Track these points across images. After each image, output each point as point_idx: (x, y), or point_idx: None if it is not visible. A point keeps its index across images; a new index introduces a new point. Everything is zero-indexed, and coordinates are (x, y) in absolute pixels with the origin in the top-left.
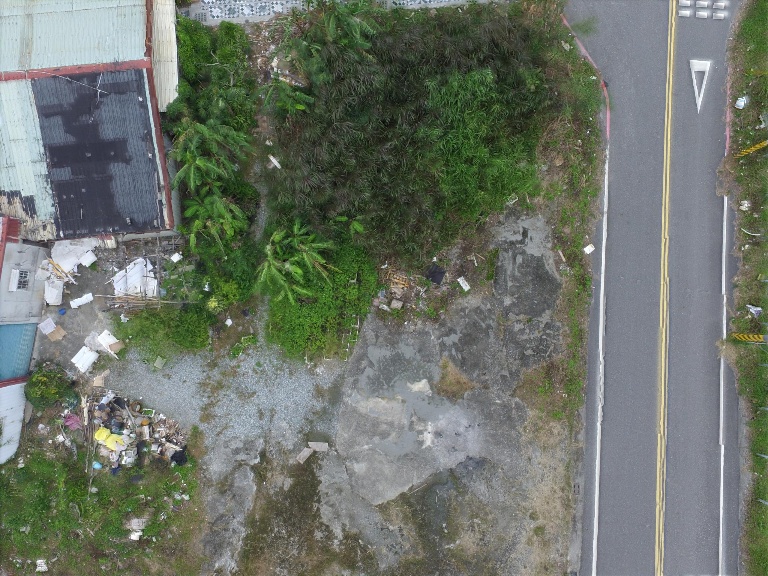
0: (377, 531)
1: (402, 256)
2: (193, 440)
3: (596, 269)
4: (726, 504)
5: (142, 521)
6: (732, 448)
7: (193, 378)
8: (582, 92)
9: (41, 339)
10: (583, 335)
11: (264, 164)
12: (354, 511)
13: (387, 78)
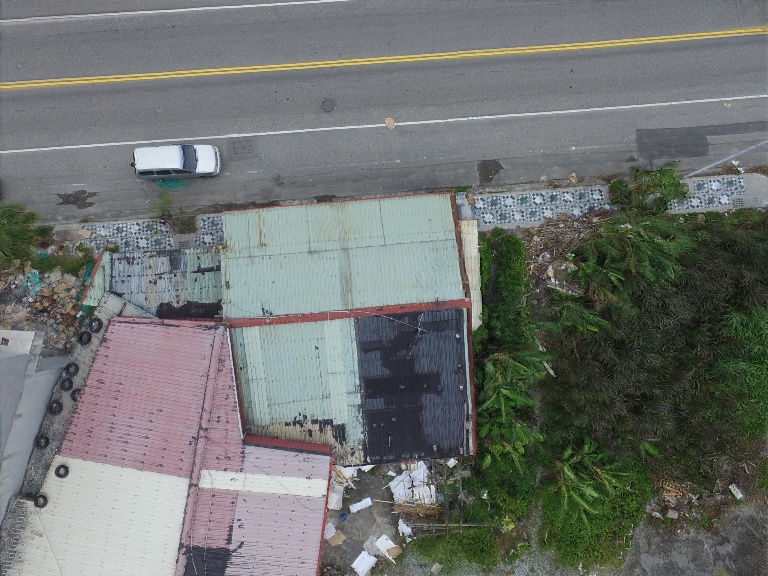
0: None
1: (693, 478)
2: None
3: None
4: None
5: None
6: None
7: None
8: None
9: None
10: None
11: (537, 370)
12: None
13: (686, 306)
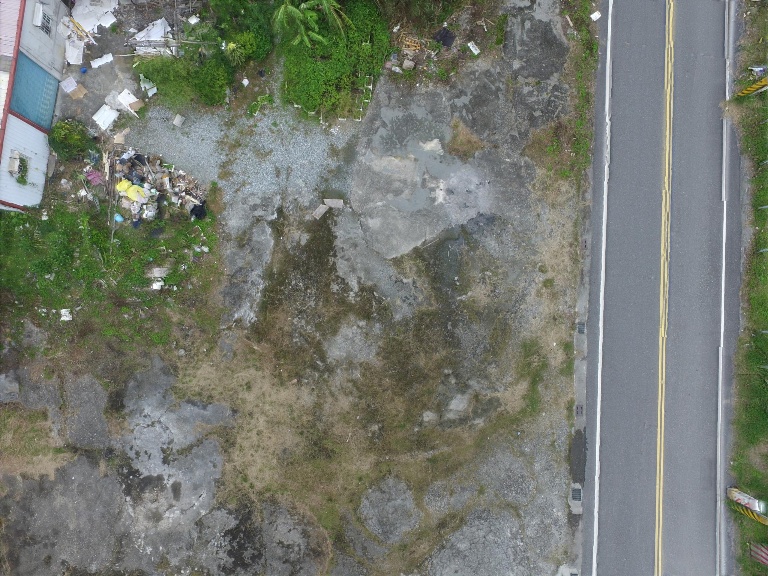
0: (391, 283)
1: (415, 4)
2: (212, 195)
3: (602, 36)
4: (728, 258)
5: (163, 269)
6: (734, 205)
7: (211, 137)
8: None
9: (63, 97)
10: (590, 98)
11: None
12: (369, 265)
13: None
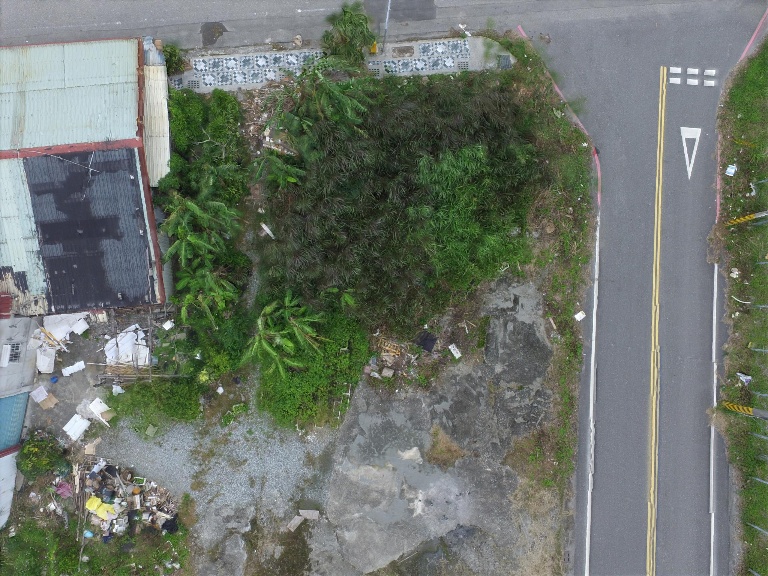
0: None
1: (393, 328)
2: (184, 508)
3: (587, 336)
4: (716, 573)
5: None
6: (722, 516)
7: (184, 446)
8: (573, 159)
9: (33, 407)
10: (574, 402)
11: (256, 232)
12: None
13: (378, 153)
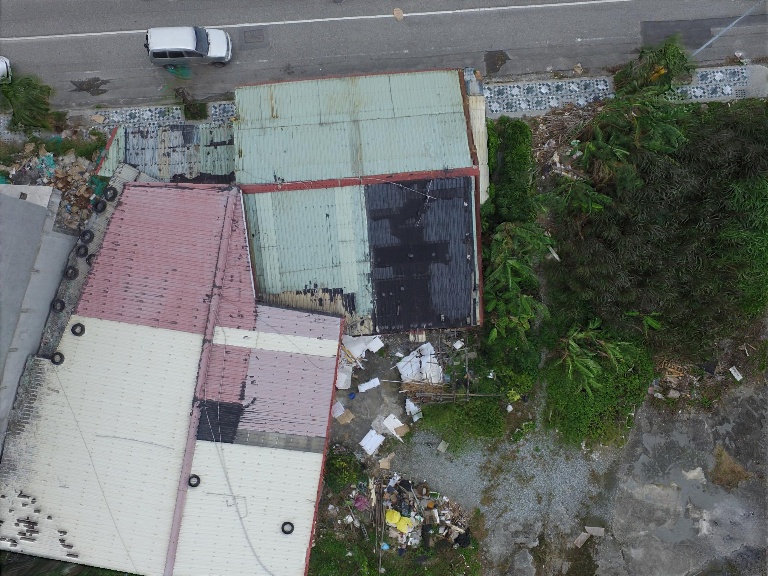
0: None
1: (695, 352)
2: (475, 523)
3: None
4: None
5: None
6: None
7: (474, 462)
8: None
9: (330, 422)
10: None
11: (543, 254)
12: None
13: None
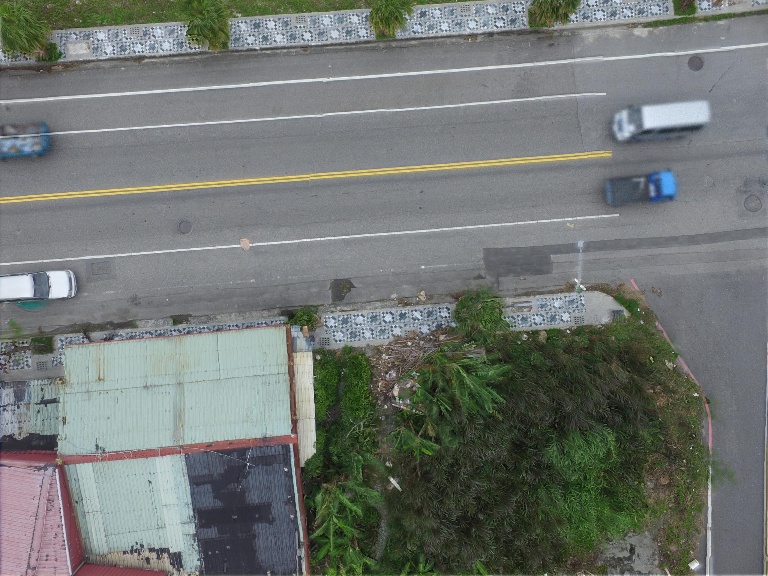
0: None
1: None
2: None
3: None
4: None
5: None
6: None
7: None
8: (685, 409)
9: None
10: None
11: (384, 485)
12: None
13: (512, 433)
